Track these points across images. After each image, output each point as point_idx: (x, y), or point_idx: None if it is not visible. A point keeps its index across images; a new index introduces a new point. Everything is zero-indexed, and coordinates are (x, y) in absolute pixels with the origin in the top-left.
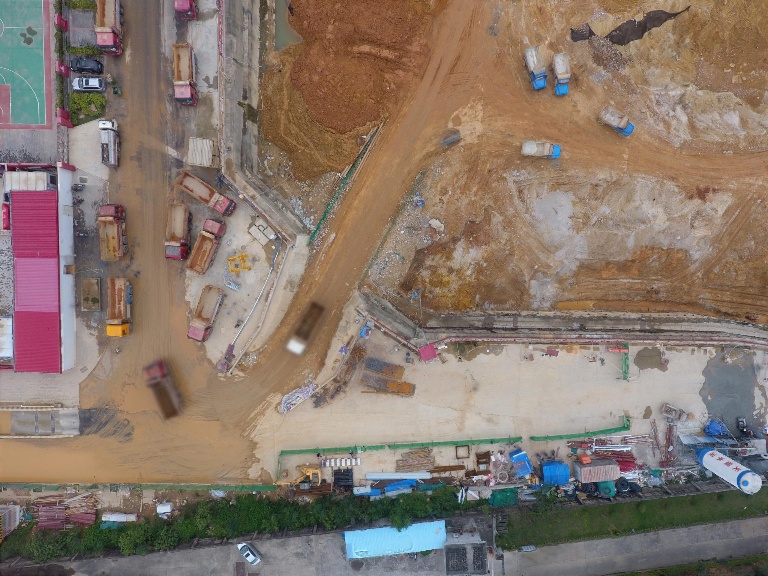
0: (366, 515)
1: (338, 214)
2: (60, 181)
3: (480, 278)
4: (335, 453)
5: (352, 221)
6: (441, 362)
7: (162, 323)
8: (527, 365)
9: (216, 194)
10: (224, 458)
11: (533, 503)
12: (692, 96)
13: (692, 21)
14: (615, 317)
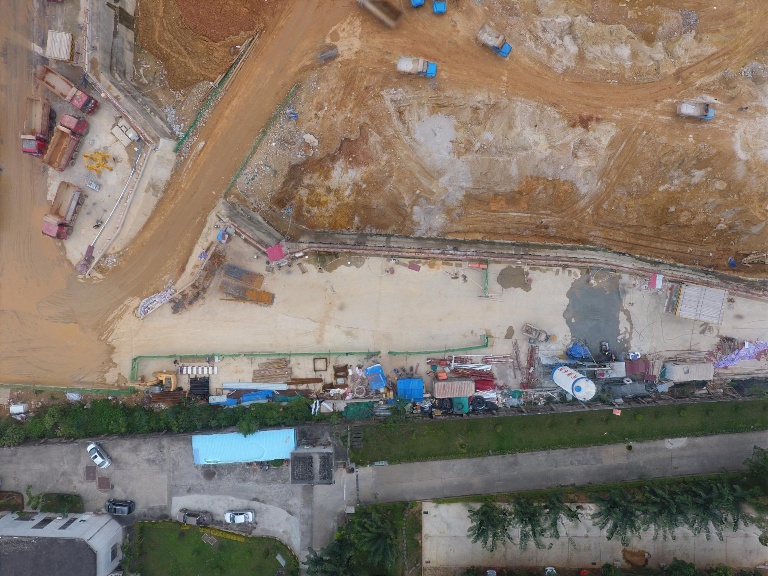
0: (214, 420)
1: (208, 123)
2: None
3: (358, 199)
4: (192, 361)
5: (222, 130)
6: (301, 272)
7: (23, 222)
8: (388, 279)
9: (73, 88)
10: (81, 361)
11: (386, 417)
12: (583, 27)
13: None
14: (489, 241)
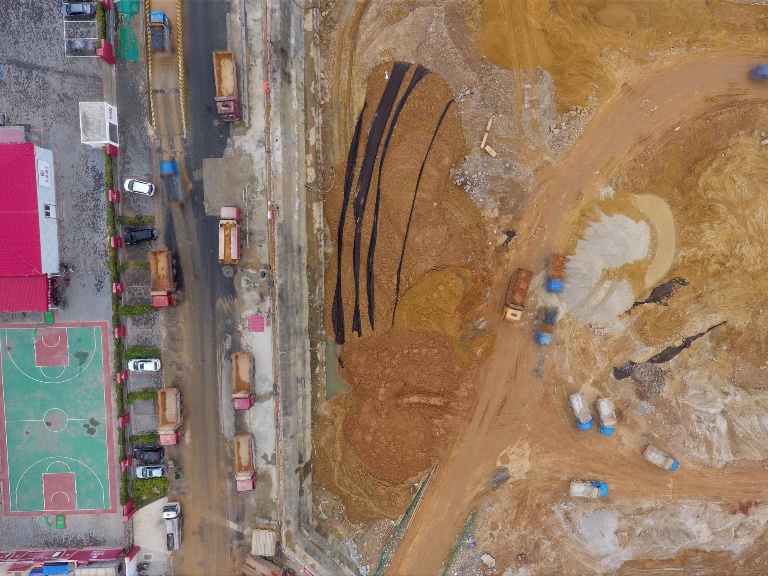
0: None
1: (393, 562)
2: (128, 574)
3: None
4: None
5: (407, 568)
6: None
7: None
8: None
9: None
10: None
11: None
12: (731, 402)
13: (729, 334)
14: None
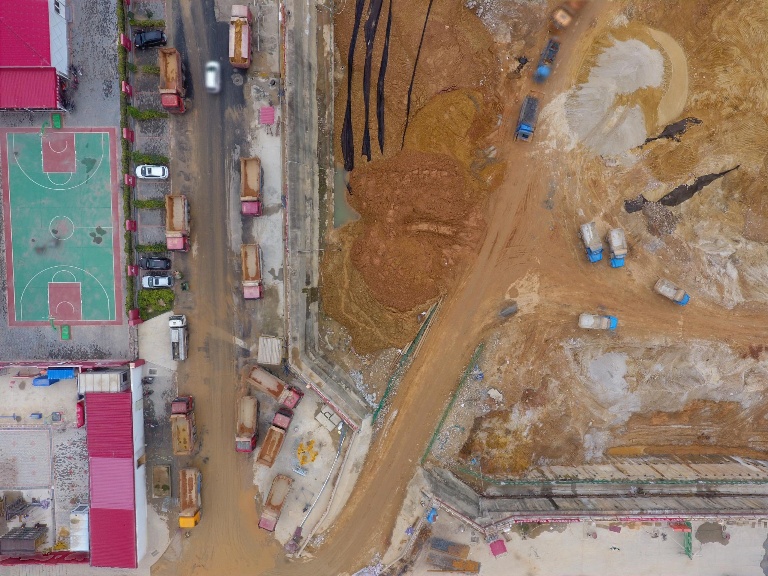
0: None
1: (400, 391)
2: (133, 381)
3: (537, 439)
4: None
5: (414, 397)
6: (506, 540)
7: (231, 506)
8: (590, 541)
9: (286, 391)
10: None
11: None
12: (742, 251)
13: (741, 179)
14: (672, 480)
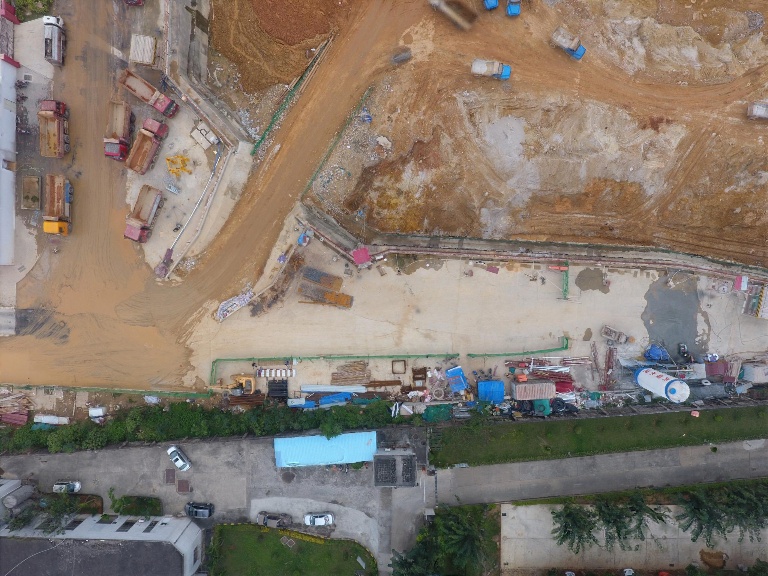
0: (296, 423)
1: (284, 125)
2: (2, 74)
3: (428, 201)
4: (270, 363)
5: (298, 133)
6: (380, 275)
7: (102, 225)
8: (467, 281)
9: (157, 92)
10: (159, 364)
11: (467, 419)
12: (650, 28)
13: None
14: (562, 243)
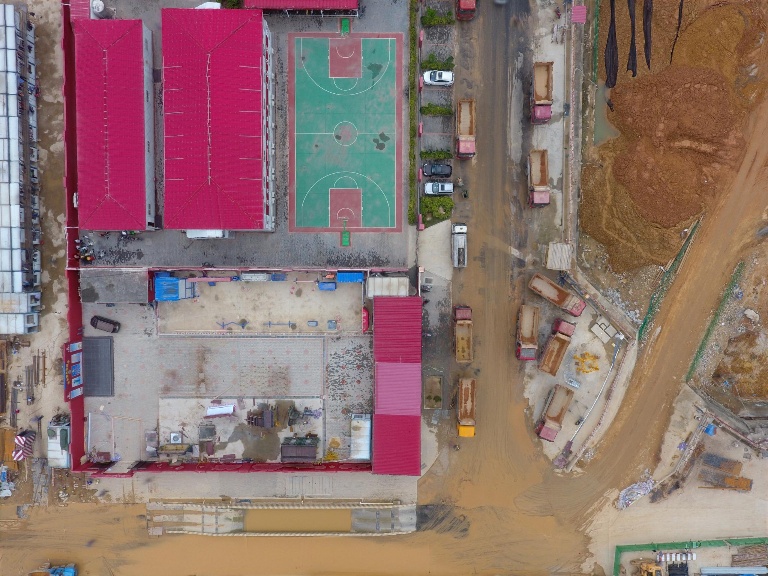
0: None
1: (663, 307)
2: None
3: None
4: (670, 548)
5: (676, 314)
6: None
7: (500, 420)
8: None
9: (574, 297)
10: (558, 553)
11: None
12: None
13: None
14: None
